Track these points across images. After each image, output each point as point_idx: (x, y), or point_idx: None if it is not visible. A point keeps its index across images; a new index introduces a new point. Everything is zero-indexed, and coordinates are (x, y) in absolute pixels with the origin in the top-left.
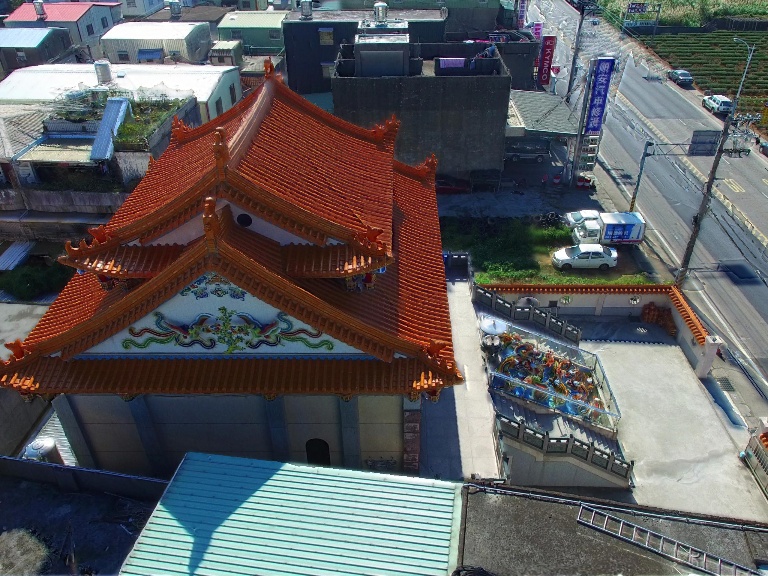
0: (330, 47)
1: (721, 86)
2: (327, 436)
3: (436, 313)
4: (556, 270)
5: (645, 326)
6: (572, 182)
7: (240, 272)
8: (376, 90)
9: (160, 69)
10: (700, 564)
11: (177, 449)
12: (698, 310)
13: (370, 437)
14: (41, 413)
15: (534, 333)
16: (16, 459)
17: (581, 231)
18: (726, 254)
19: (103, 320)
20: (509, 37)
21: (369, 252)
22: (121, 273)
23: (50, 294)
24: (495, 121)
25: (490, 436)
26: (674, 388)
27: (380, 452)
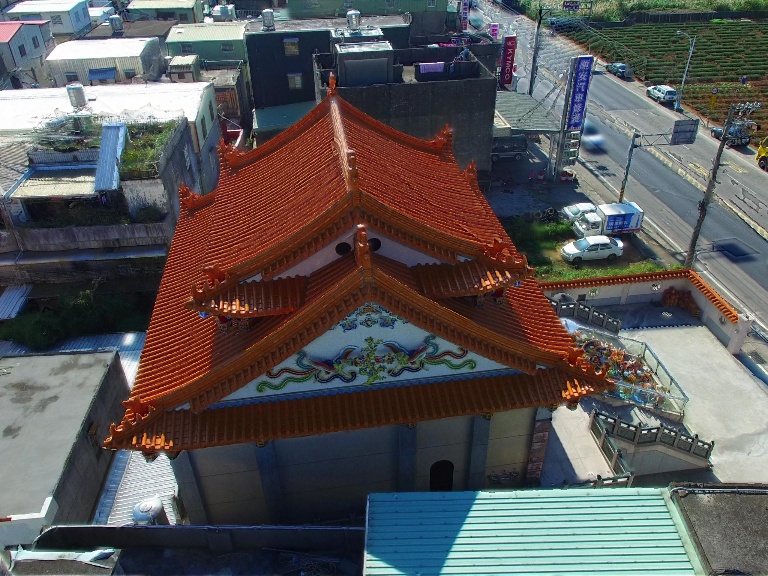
0: (295, 57)
1: (658, 76)
2: (454, 456)
3: (549, 320)
4: (568, 264)
5: (668, 310)
6: (556, 177)
7: (395, 299)
8: (366, 99)
9: (132, 89)
10: None
11: (296, 490)
12: None
13: (496, 452)
14: (106, 471)
15: (589, 328)
16: (160, 527)
17: (583, 224)
18: (716, 235)
19: (238, 365)
20: (471, 39)
21: (504, 266)
22: (251, 312)
23: (68, 340)
24: (482, 123)
25: (589, 435)
26: (715, 366)
27: (503, 465)
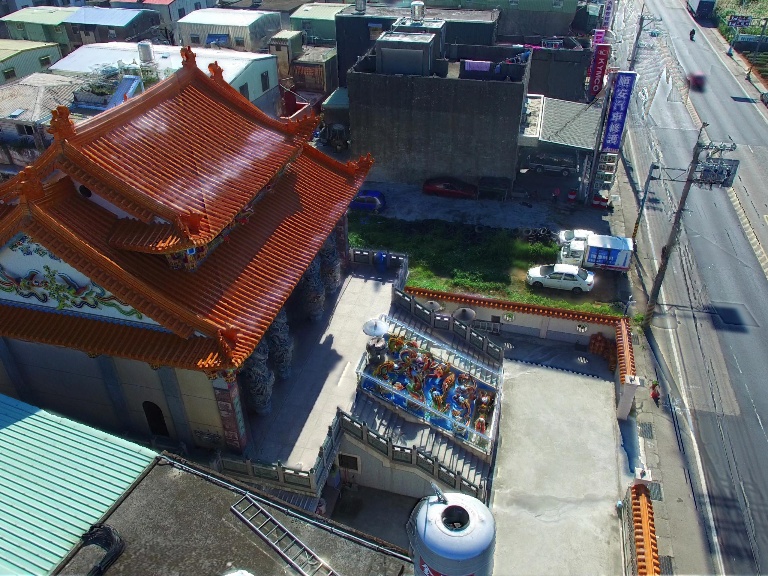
0: None
1: None
2: (158, 401)
3: (267, 302)
4: (526, 287)
5: (588, 356)
6: (587, 200)
7: (51, 236)
8: (389, 87)
9: (202, 53)
10: (310, 571)
11: (41, 390)
12: (657, 349)
13: (195, 409)
14: None
15: (436, 342)
16: None
17: (566, 250)
18: (722, 295)
19: None
20: (562, 44)
21: (181, 233)
22: None
23: None
24: (507, 128)
25: None
26: (584, 424)
27: (207, 425)
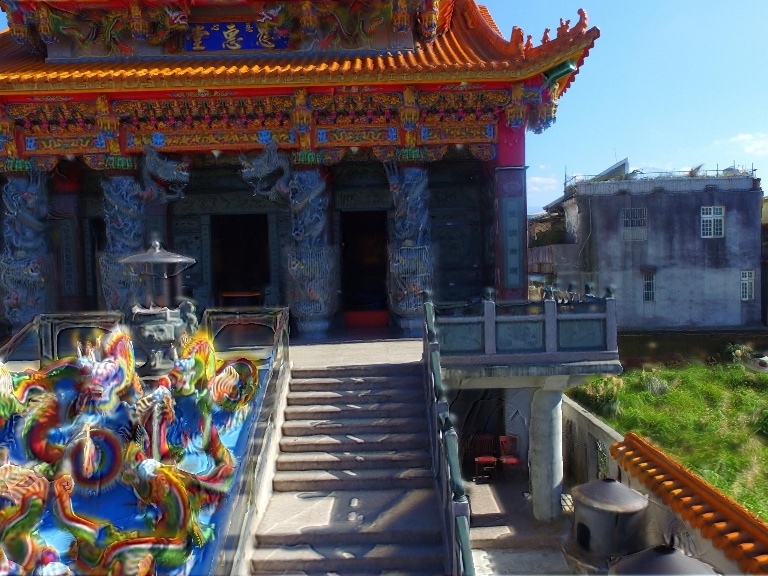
0: None
1: None
2: None
3: None
4: None
5: None
6: None
7: None
8: None
9: None
10: None
11: None
12: None
13: None
14: None
15: (256, 420)
16: None
17: None
18: None
19: None
20: None
21: None
22: None
23: None
24: None
25: None
26: None
27: None
